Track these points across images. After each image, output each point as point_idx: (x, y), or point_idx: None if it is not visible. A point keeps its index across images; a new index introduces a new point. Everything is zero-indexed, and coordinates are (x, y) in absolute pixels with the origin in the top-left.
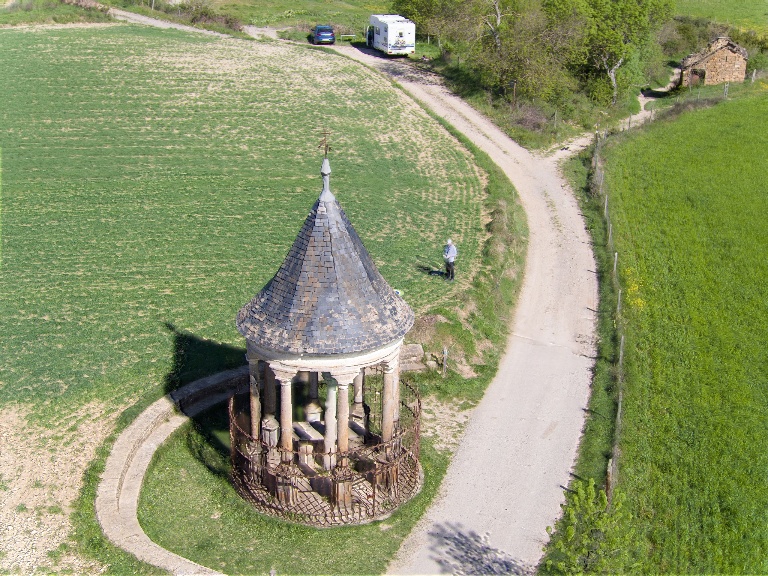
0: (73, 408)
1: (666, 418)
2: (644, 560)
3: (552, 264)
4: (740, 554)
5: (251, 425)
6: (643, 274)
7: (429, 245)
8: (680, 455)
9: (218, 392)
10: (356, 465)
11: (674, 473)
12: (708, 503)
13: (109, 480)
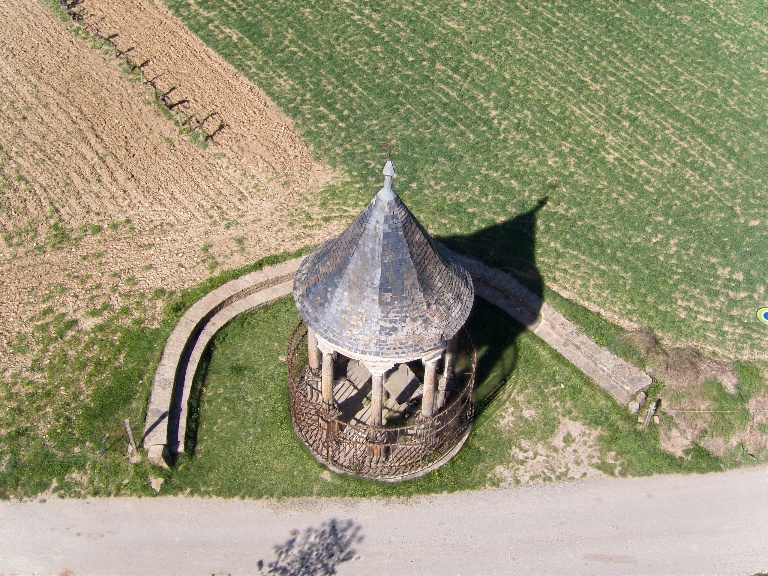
0: None
1: None
2: None
3: None
4: None
5: None
6: None
7: None
8: None
9: None
10: (390, 418)
11: None
12: None
13: (262, 274)
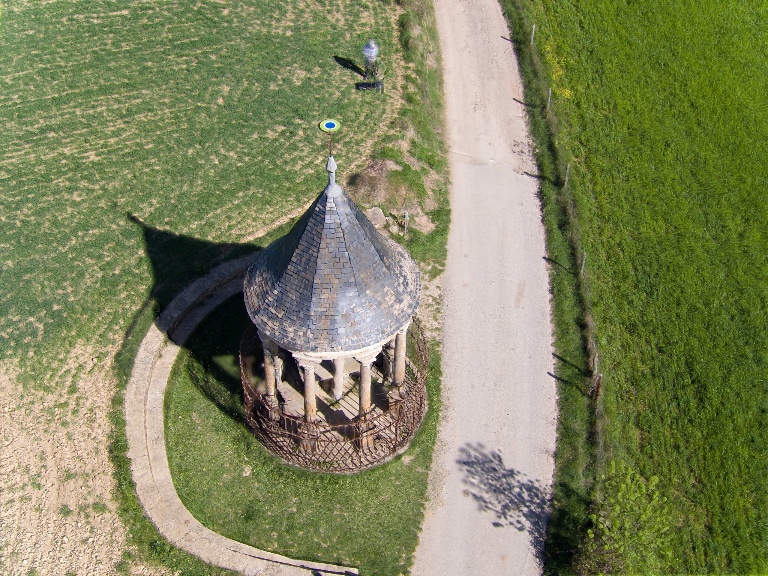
0: (62, 360)
1: (621, 260)
2: (638, 456)
3: (464, 31)
4: (717, 435)
5: (266, 385)
6: (557, 37)
7: (343, 36)
8: (642, 309)
9: (197, 306)
10: None
11: (642, 336)
12: (679, 374)
13: (139, 460)
